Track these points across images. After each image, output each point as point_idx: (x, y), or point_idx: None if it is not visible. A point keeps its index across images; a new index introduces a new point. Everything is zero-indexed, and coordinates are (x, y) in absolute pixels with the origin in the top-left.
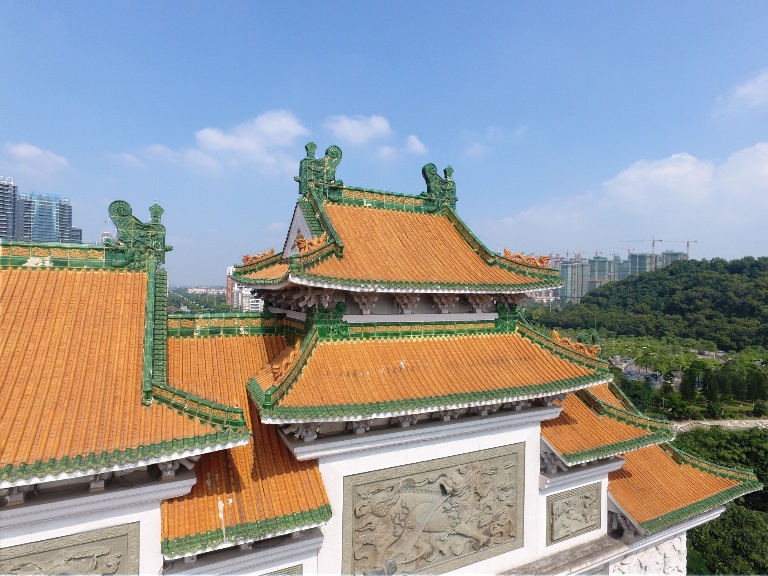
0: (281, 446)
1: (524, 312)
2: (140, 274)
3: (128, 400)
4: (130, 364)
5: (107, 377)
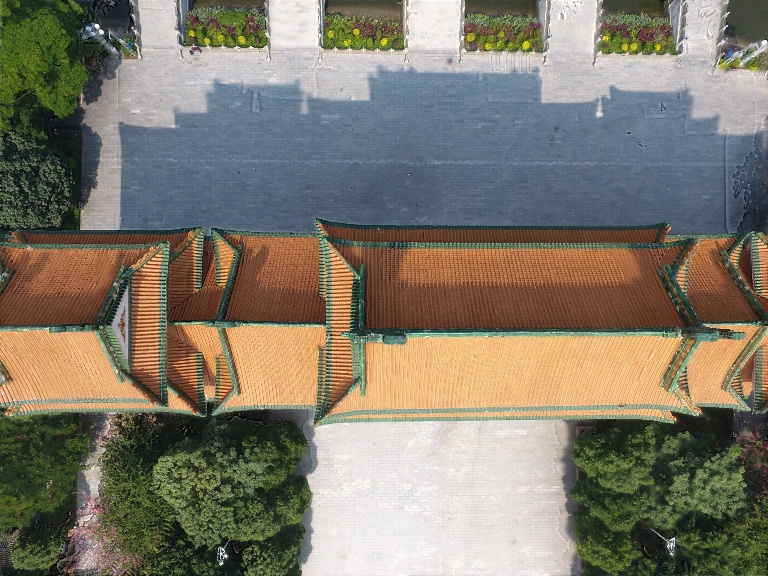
0: (750, 372)
1: None
2: (756, 327)
3: (717, 384)
4: (725, 370)
5: (715, 374)
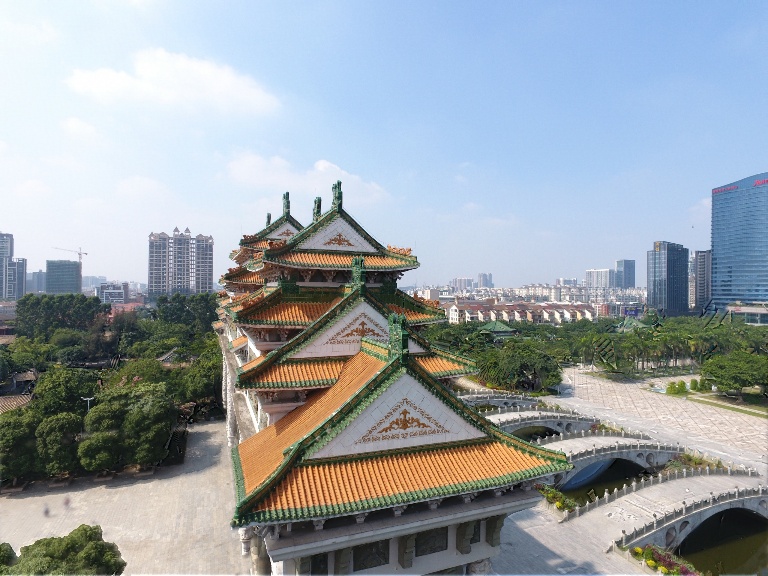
0: None
1: (360, 286)
2: None
3: None
4: None
5: None
